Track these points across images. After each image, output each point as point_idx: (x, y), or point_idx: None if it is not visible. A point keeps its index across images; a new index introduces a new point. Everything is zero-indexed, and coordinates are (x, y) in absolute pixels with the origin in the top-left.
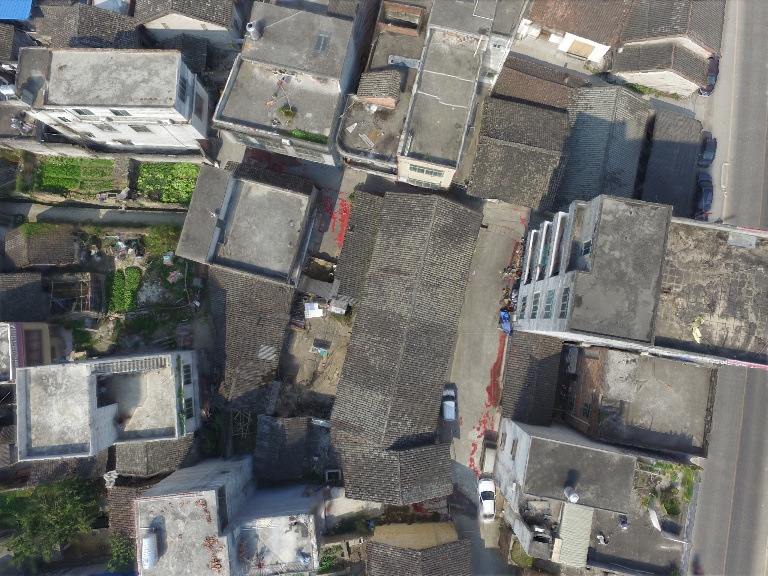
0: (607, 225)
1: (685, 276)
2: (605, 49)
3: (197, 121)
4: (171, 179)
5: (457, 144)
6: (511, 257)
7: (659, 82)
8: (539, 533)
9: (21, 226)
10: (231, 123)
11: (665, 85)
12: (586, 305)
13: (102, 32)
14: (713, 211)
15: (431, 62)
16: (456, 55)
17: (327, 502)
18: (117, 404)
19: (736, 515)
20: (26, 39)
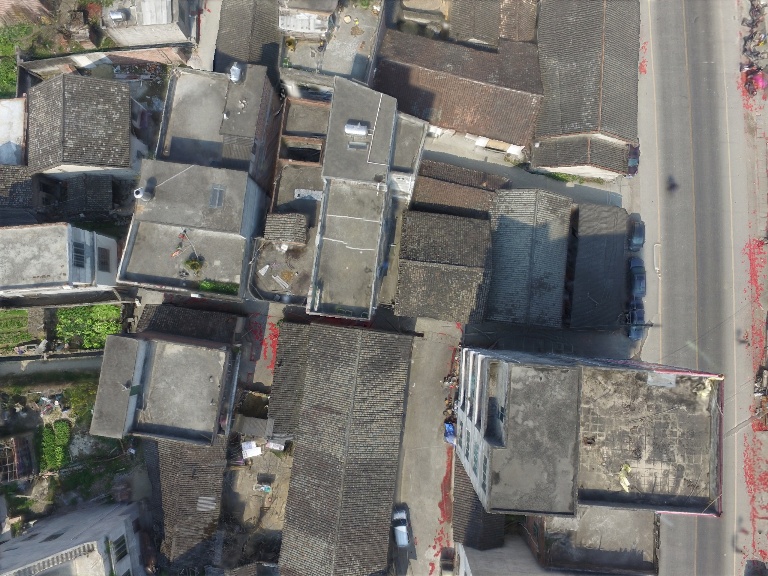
0: (518, 394)
1: (608, 423)
2: (521, 146)
3: (103, 277)
4: (91, 323)
5: (369, 290)
6: (450, 364)
7: (581, 171)
8: None
9: None
10: (136, 283)
11: (587, 173)
12: (504, 481)
13: None
14: (649, 295)
15: (333, 205)
16: (358, 195)
17: None
18: None
19: None
20: None
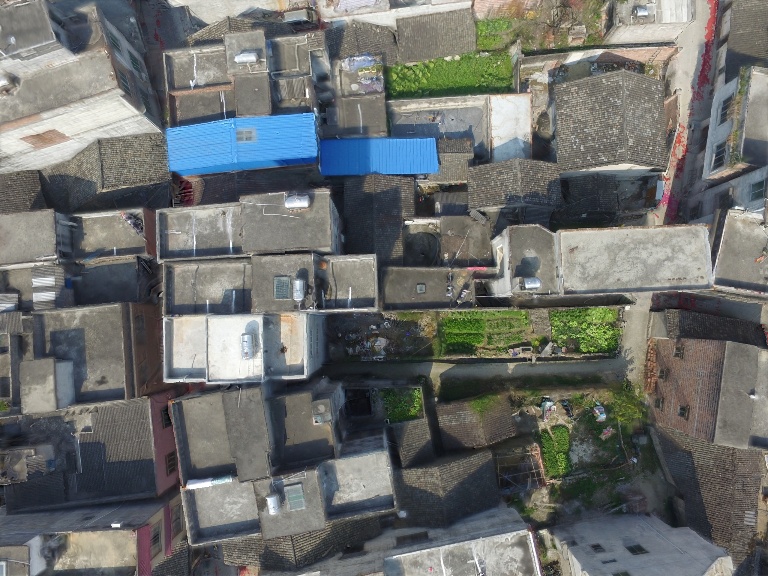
0: None
1: None
2: None
3: None
4: (586, 327)
5: None
6: None
7: None
8: None
9: (470, 403)
10: (733, 287)
11: None
12: None
13: (537, 186)
14: None
15: None
16: None
17: None
18: None
19: None
20: (415, 187)
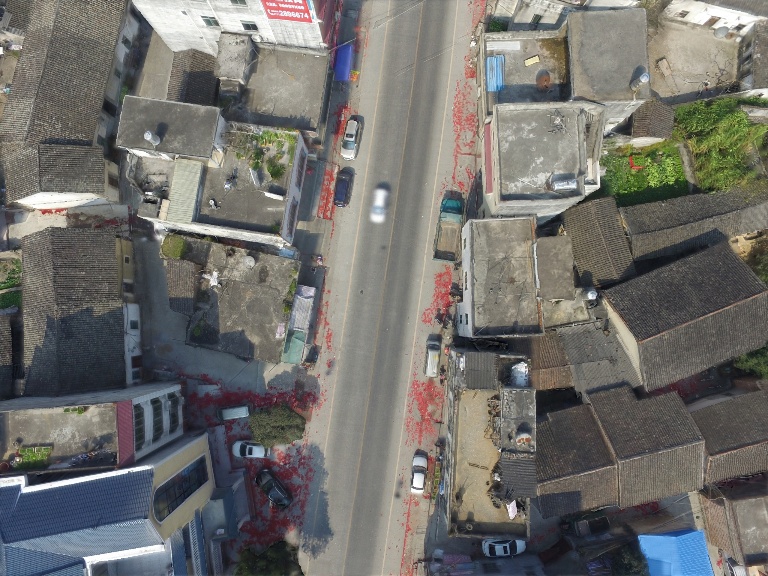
0: None
1: None
2: None
3: None
4: None
5: None
6: None
7: None
8: (148, 195)
9: None
10: None
11: None
12: None
13: None
14: None
15: None
16: None
17: (10, 226)
18: None
19: (398, 226)
20: None
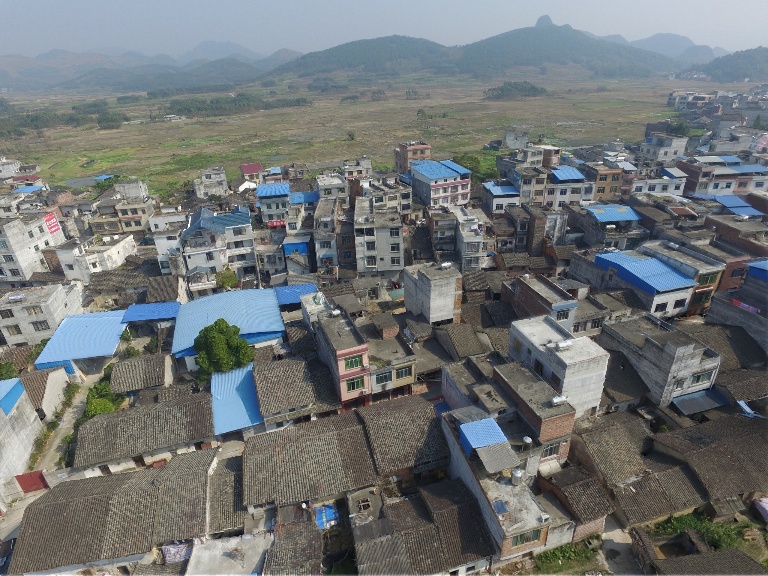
0: None
1: None
2: None
3: None
4: None
5: None
6: None
7: None
8: None
9: None
10: None
11: None
12: None
13: None
14: None
15: None
16: None
17: None
18: None
19: None
20: None
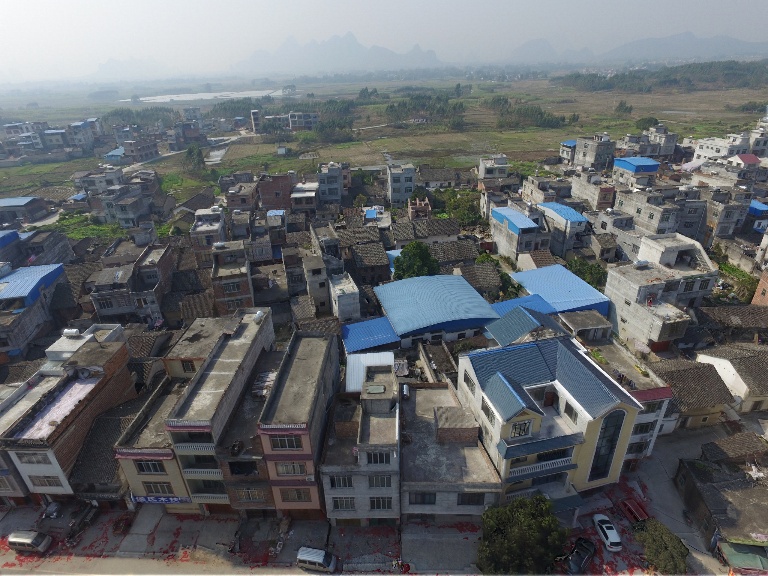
0: None
1: None
2: None
3: None
4: None
5: None
6: None
7: None
8: None
9: None
10: None
11: None
12: None
13: None
14: None
15: None
16: None
17: None
18: (674, 265)
19: None
20: None
